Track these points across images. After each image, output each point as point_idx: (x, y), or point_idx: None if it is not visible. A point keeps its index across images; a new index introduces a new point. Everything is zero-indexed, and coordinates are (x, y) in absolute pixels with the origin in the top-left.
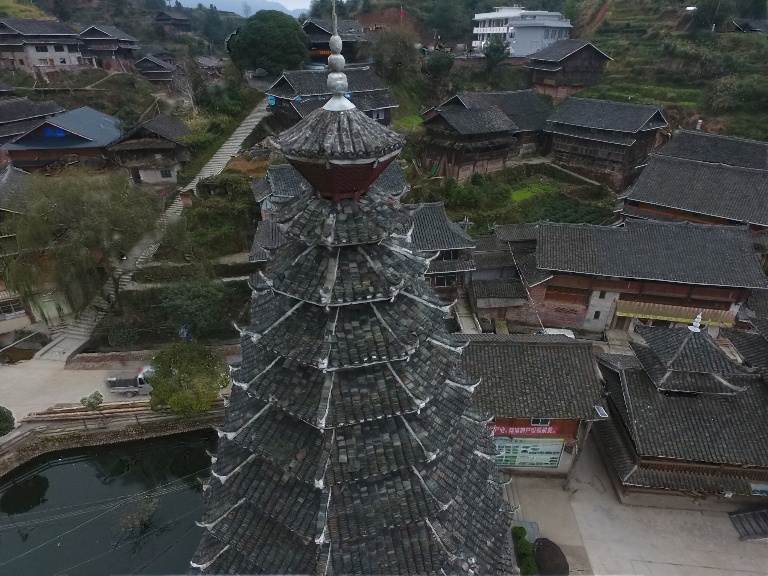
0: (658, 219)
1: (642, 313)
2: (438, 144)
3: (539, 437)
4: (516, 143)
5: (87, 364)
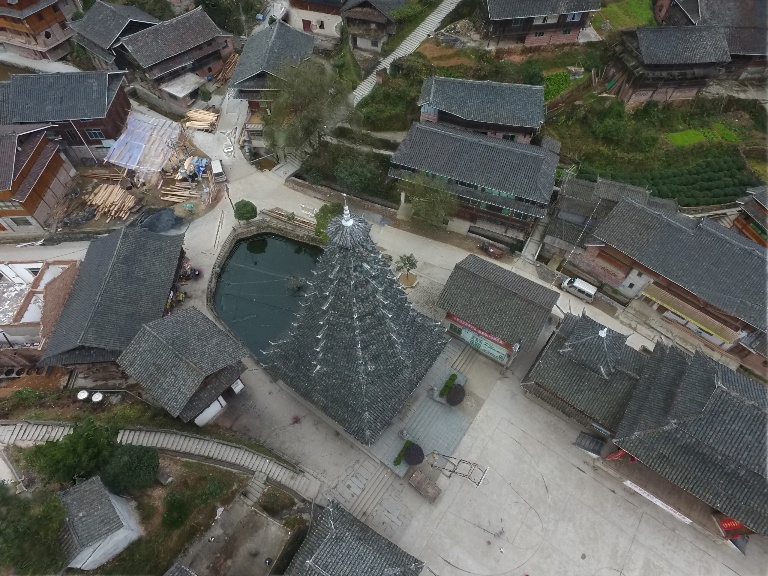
0: (767, 227)
1: (662, 301)
2: (624, 61)
3: (494, 342)
4: (739, 65)
5: (295, 186)
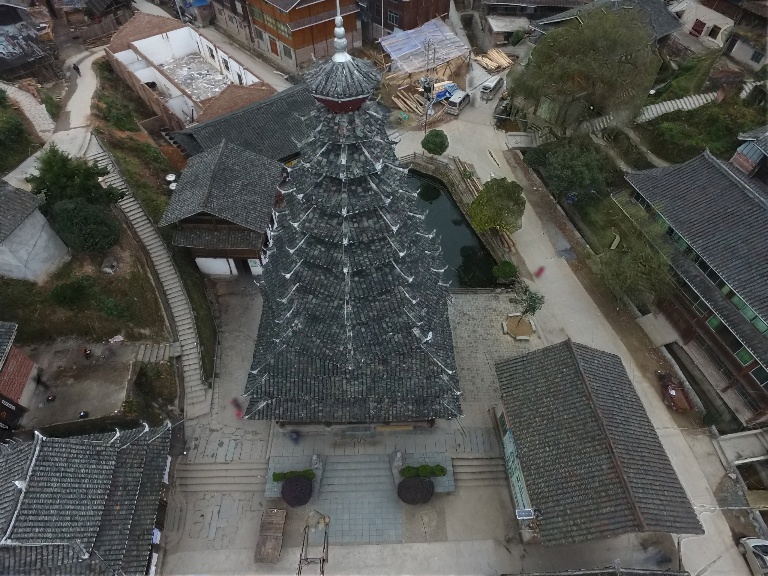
0: None
1: None
2: None
3: None
4: None
5: (512, 159)
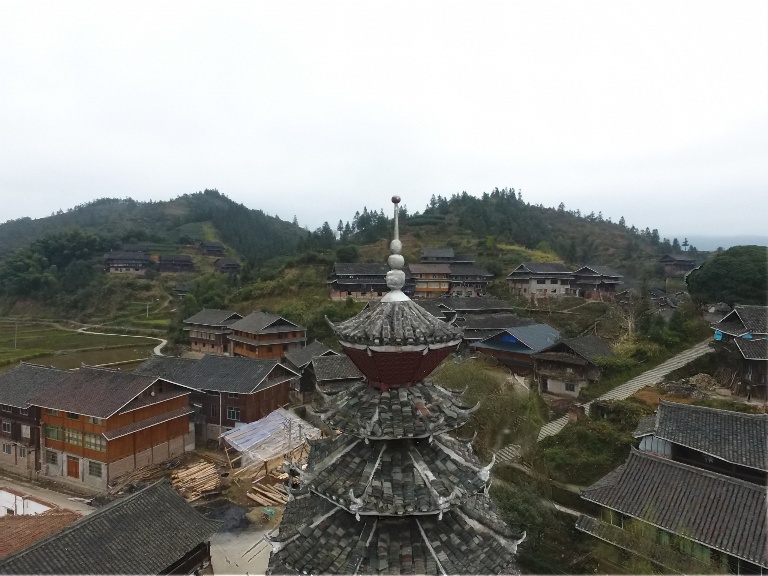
0: None
1: None
2: None
3: None
4: None
5: None
